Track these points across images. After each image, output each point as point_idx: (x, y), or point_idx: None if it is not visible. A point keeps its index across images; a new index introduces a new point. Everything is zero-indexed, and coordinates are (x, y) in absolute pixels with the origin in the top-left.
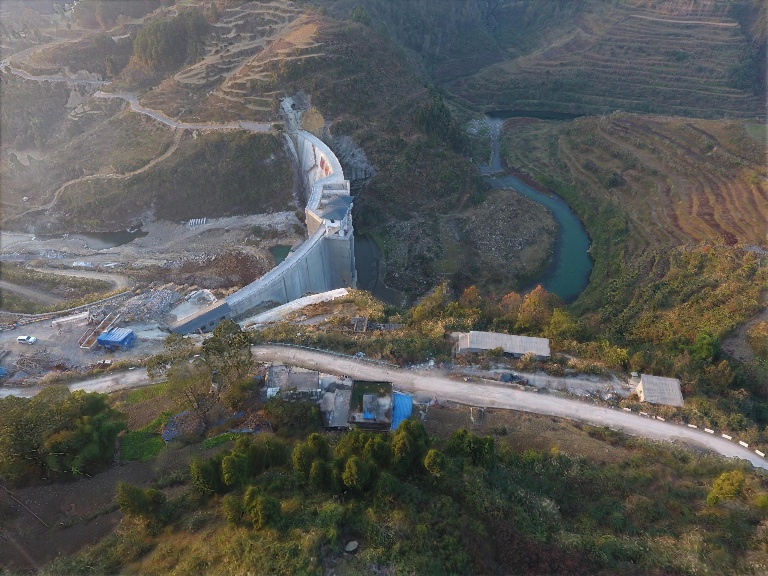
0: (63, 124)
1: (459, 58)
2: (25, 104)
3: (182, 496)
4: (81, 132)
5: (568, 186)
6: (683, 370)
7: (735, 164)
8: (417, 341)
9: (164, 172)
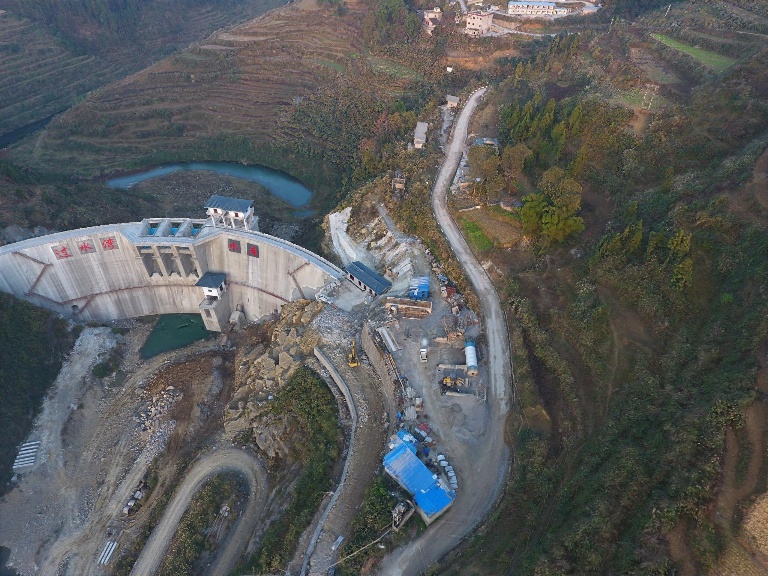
0: None
1: None
2: None
3: None
4: None
5: (156, 154)
6: None
7: (215, 77)
8: (429, 146)
9: None
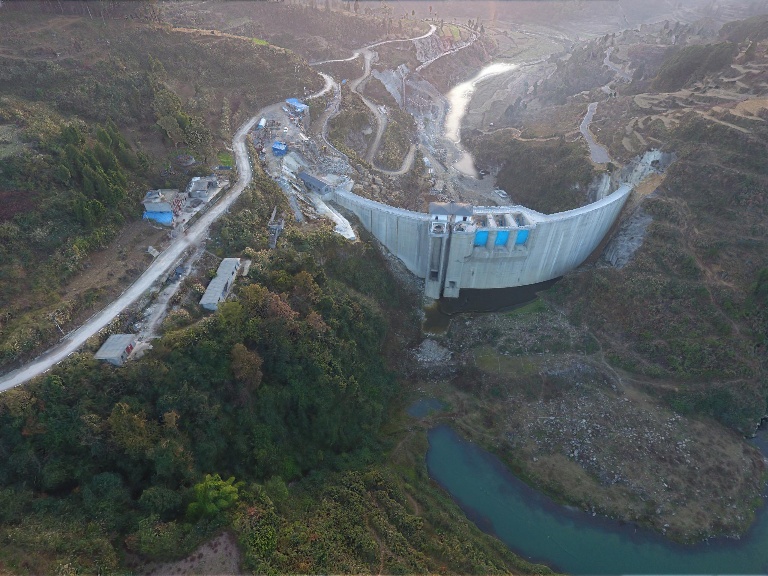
0: None
1: None
2: None
3: None
4: None
5: None
6: (129, 370)
7: None
8: None
9: (524, 147)
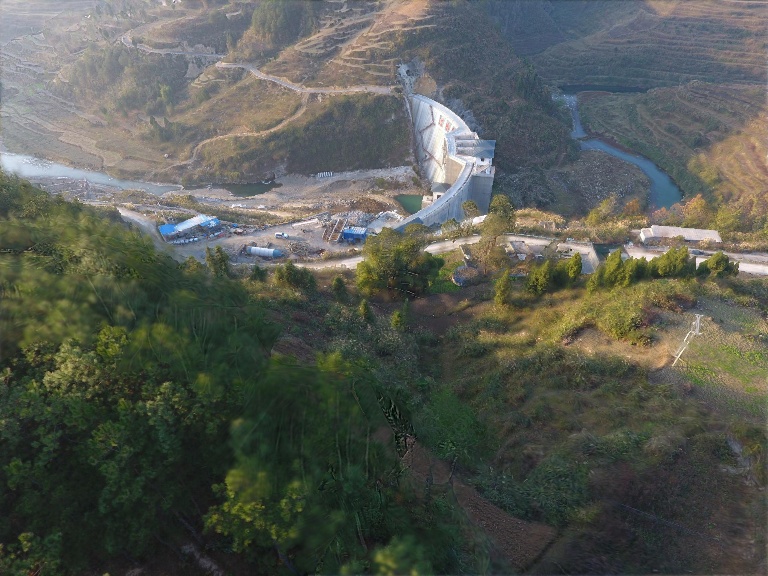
0: (189, 91)
1: (523, 39)
2: (151, 74)
3: (520, 296)
4: (209, 98)
5: (653, 147)
6: None
7: None
8: (616, 229)
9: (298, 130)
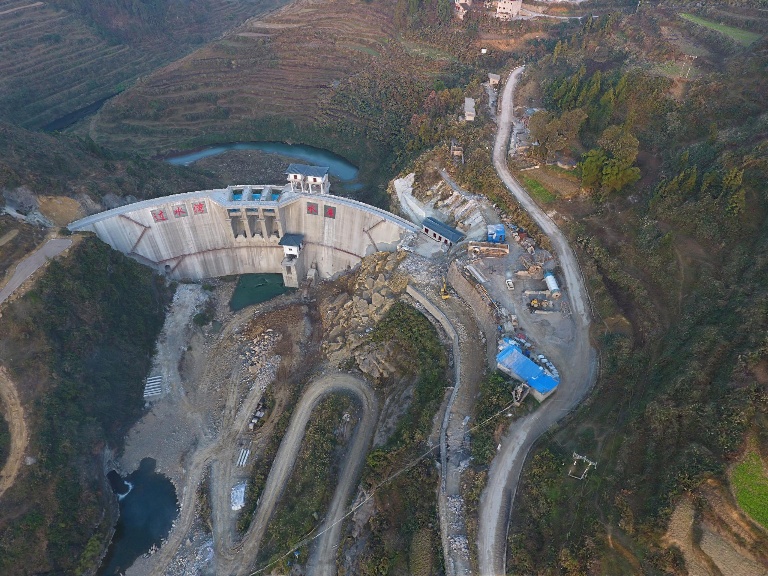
0: None
1: None
2: None
3: None
4: None
5: (206, 136)
6: None
7: (254, 63)
8: None
9: (62, 389)
